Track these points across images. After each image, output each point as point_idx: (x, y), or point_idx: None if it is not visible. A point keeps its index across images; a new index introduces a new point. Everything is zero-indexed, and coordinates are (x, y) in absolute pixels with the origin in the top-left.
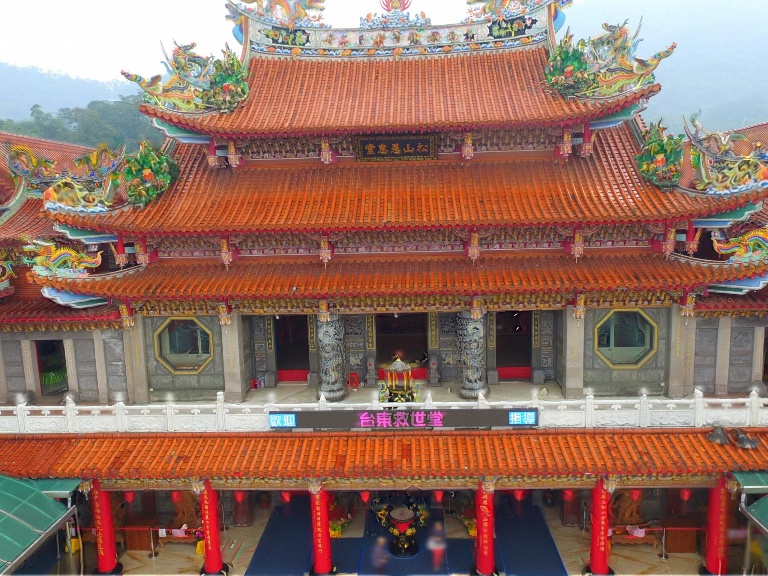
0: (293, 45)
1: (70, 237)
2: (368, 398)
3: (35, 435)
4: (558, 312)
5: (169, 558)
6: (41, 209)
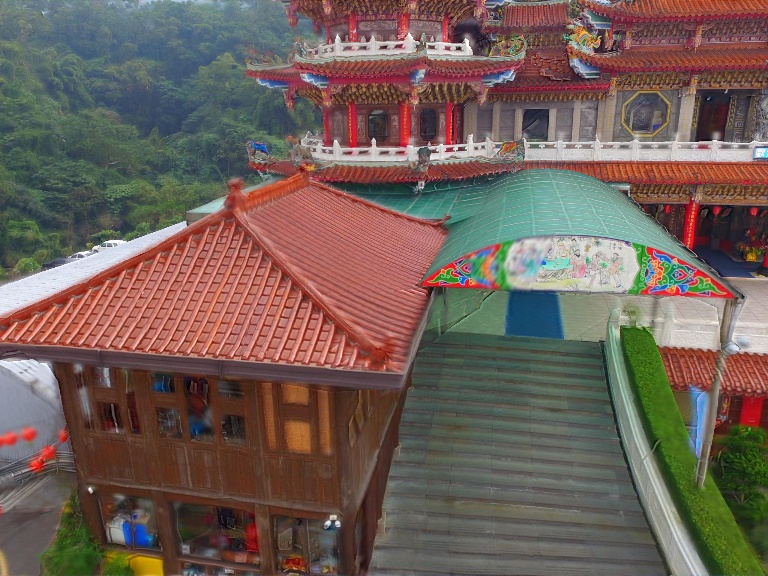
0: None
1: (590, 21)
2: None
3: (572, 161)
4: None
5: None
6: None
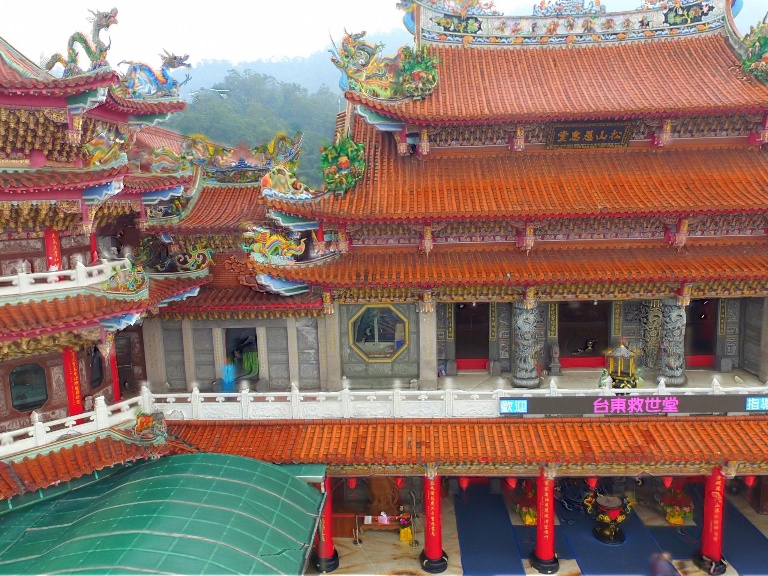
0: (465, 33)
1: (282, 224)
2: (563, 386)
3: (261, 421)
4: (753, 300)
5: (375, 545)
6: (259, 196)
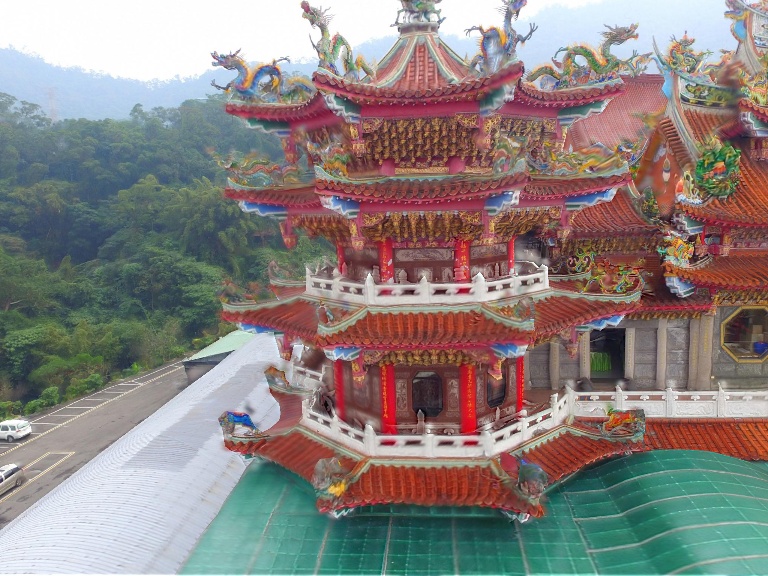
0: None
1: (686, 228)
2: None
3: (691, 419)
4: None
5: None
6: (676, 201)
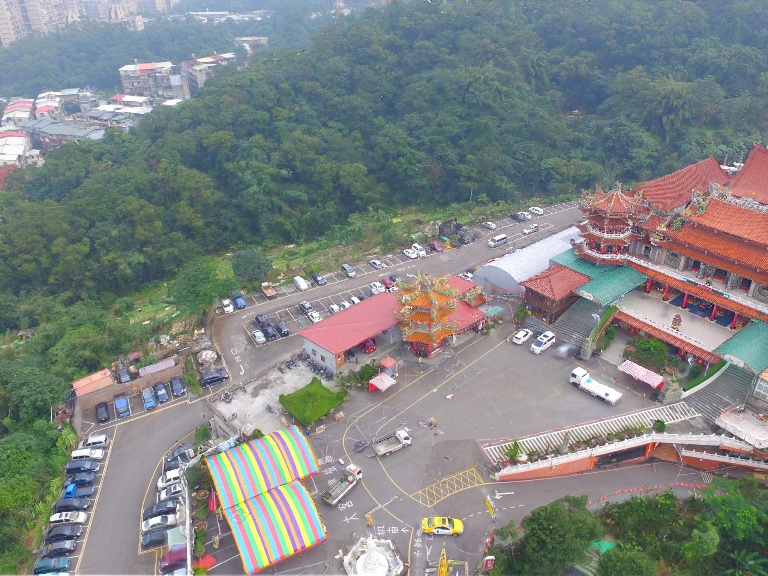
0: None
1: None
2: None
3: (643, 266)
4: None
5: (658, 294)
6: (655, 229)
